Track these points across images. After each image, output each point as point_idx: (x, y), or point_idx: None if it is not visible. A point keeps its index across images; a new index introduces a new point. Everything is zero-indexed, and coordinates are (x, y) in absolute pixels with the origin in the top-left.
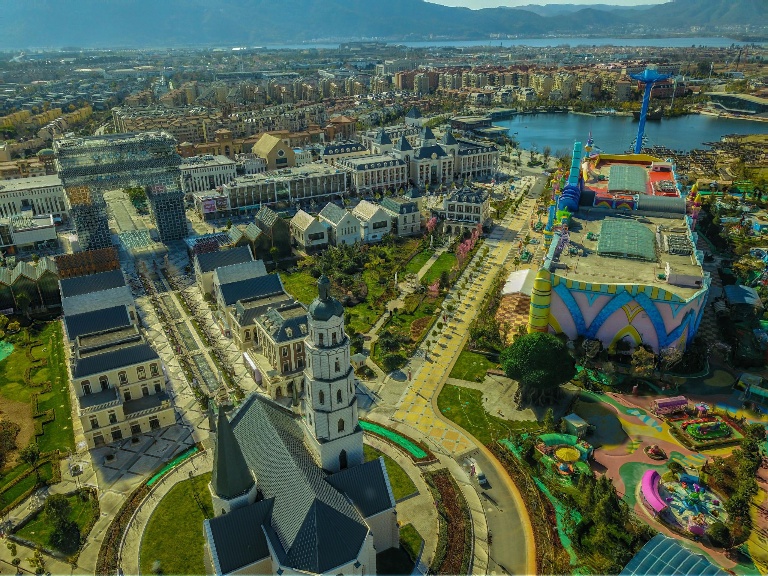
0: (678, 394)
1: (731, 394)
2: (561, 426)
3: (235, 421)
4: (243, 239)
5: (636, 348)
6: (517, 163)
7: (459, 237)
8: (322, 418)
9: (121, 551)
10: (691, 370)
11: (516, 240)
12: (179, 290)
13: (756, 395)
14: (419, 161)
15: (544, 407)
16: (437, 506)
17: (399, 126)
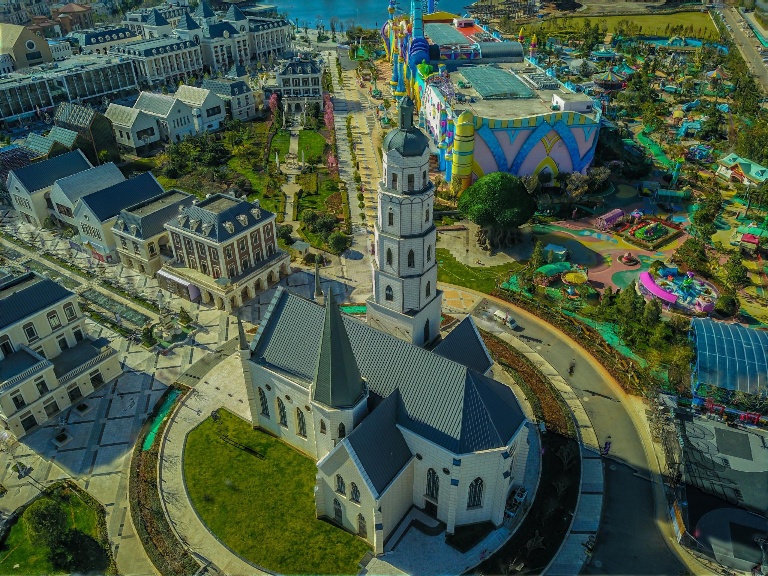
0: (606, 210)
1: (643, 201)
2: None
3: (268, 329)
4: (56, 147)
5: (556, 178)
6: (305, 39)
7: (311, 112)
8: (413, 285)
9: (177, 534)
10: (603, 189)
11: (364, 109)
12: None
13: (663, 196)
14: (212, 41)
15: (512, 247)
16: (496, 359)
17: (162, 6)
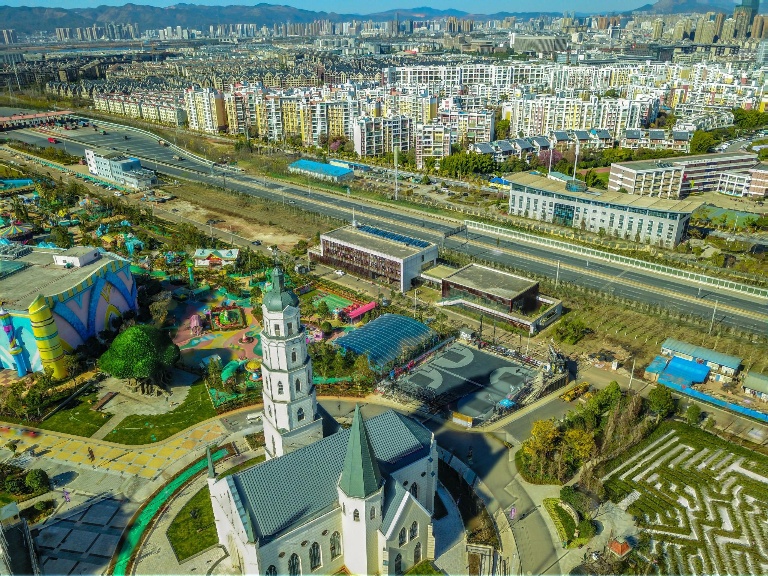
0: (180, 322)
1: (188, 304)
2: (207, 372)
3: None
4: None
5: (125, 318)
6: None
7: None
8: None
9: None
10: None
11: None
12: None
13: (198, 294)
14: None
15: (173, 380)
16: None
17: None
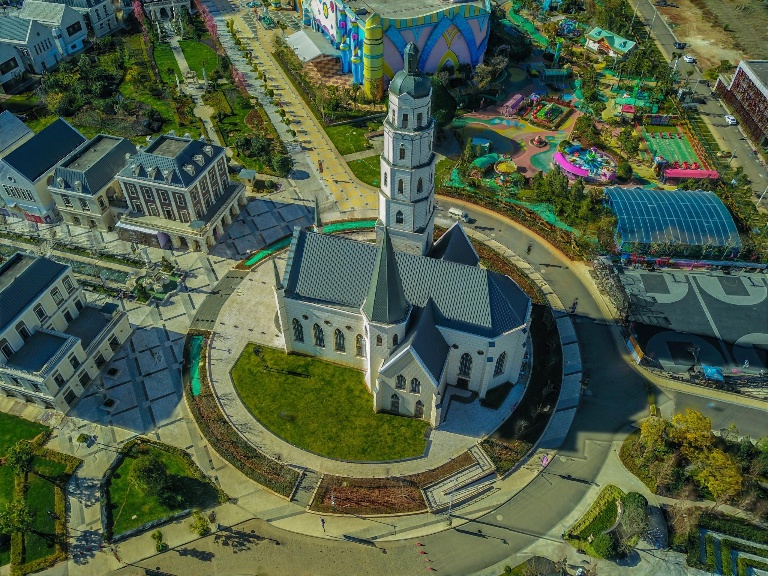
0: (506, 96)
1: (533, 83)
2: None
3: (294, 266)
4: None
5: (458, 70)
6: None
7: (185, 18)
8: (421, 207)
9: (266, 454)
10: None
11: (236, 8)
12: None
13: (550, 76)
14: None
15: (440, 145)
16: None
17: None
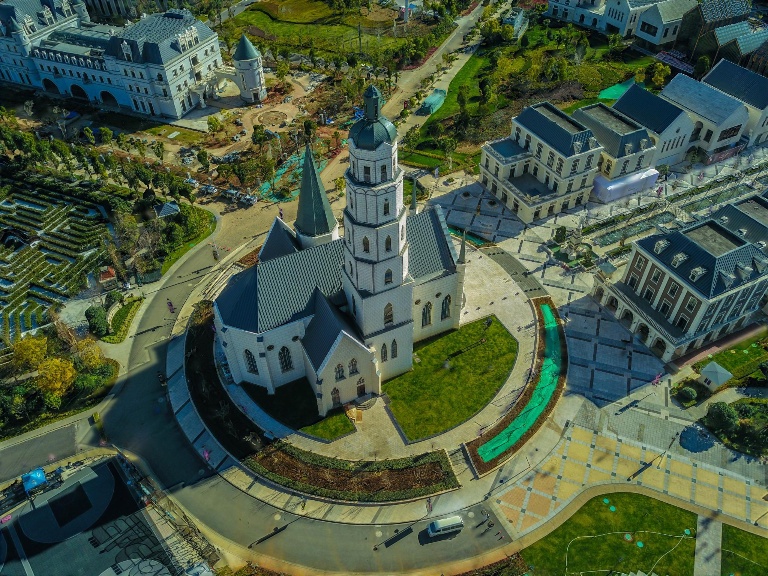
0: None
1: None
2: None
3: None
4: None
5: None
6: None
7: None
8: None
9: None
10: None
11: None
12: None
13: None
14: None
15: None
16: None
17: None
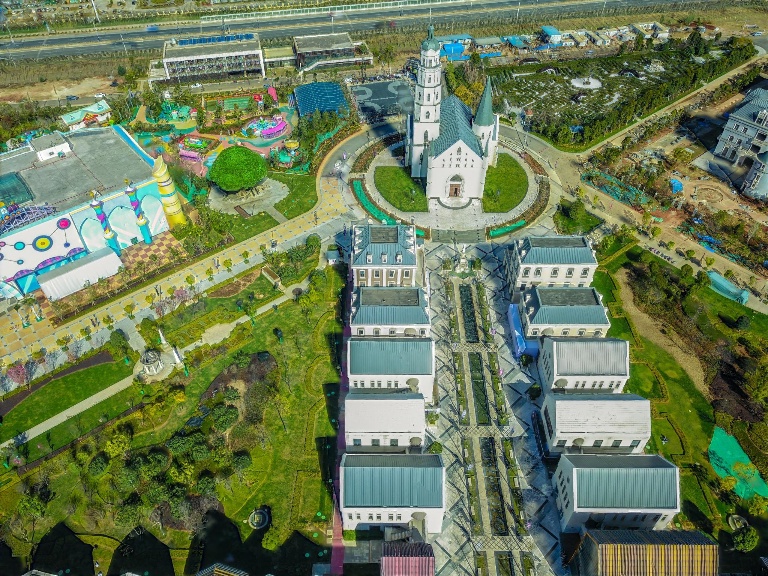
0: None
1: None
2: None
3: None
4: None
5: None
6: None
7: None
8: None
9: None
10: None
11: None
12: (474, 546)
13: None
14: None
15: None
16: None
17: None
